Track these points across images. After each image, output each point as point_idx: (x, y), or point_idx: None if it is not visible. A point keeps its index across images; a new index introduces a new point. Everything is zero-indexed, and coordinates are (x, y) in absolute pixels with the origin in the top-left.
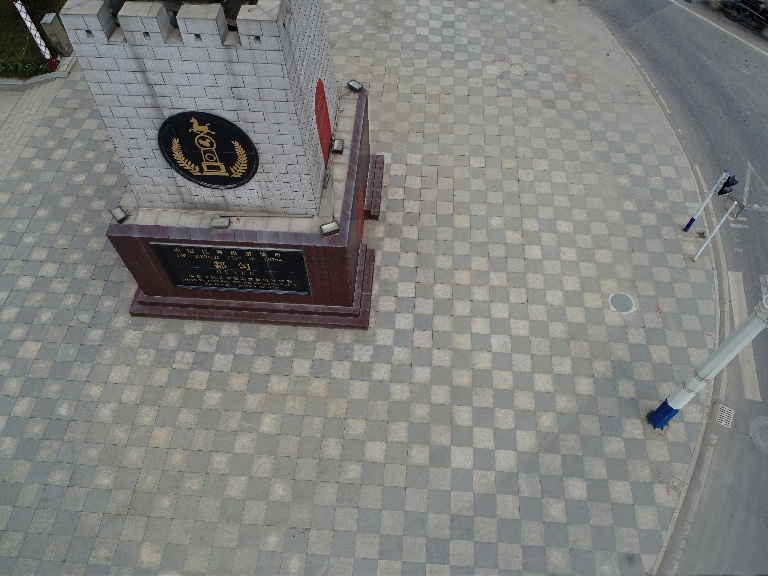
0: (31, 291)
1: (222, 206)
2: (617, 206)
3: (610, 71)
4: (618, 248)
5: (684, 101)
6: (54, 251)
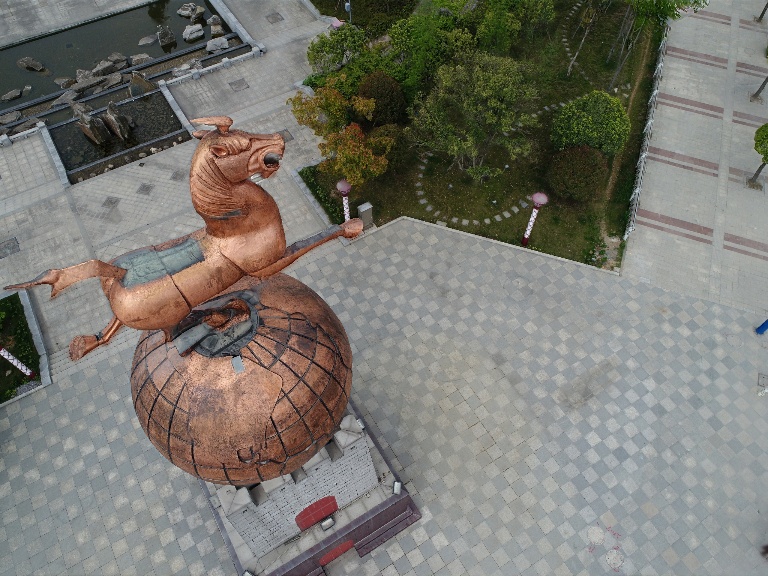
0: None
1: None
2: None
3: None
4: None
5: None
6: None
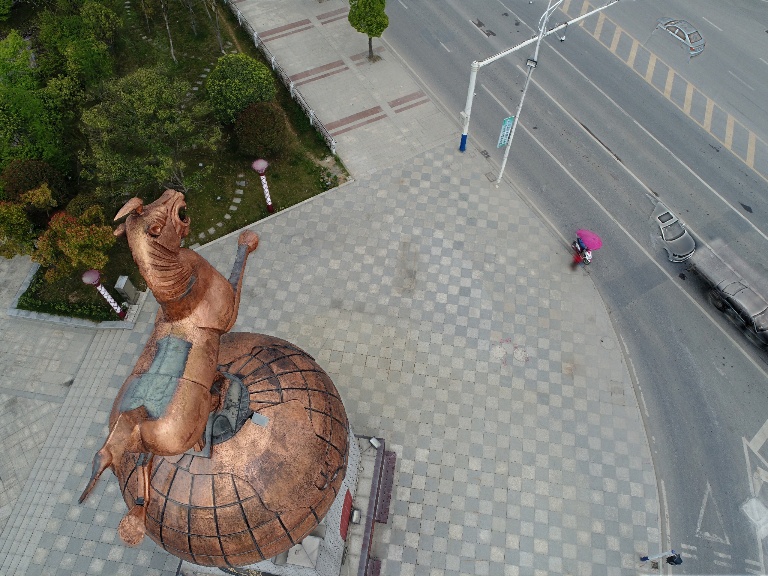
0: None
1: None
2: (588, 526)
3: (601, 362)
4: (583, 575)
5: (662, 403)
6: None
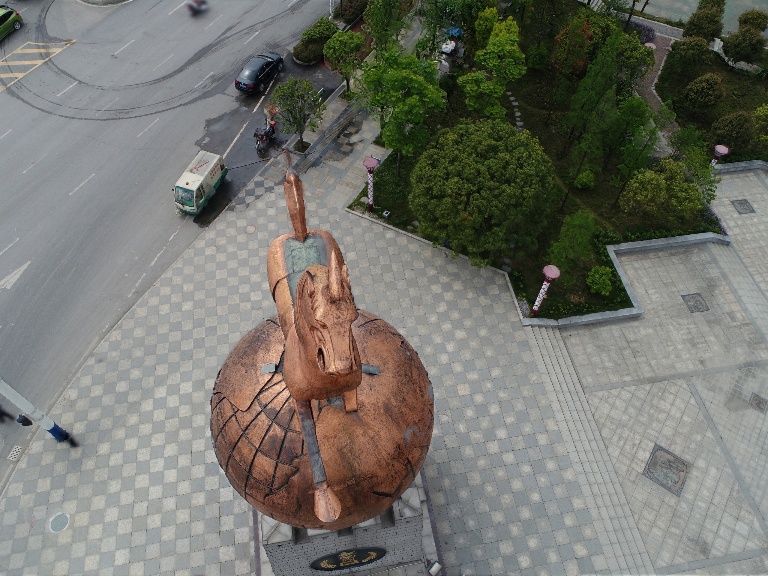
0: (492, 428)
1: None
2: None
3: None
4: None
5: None
6: (500, 463)
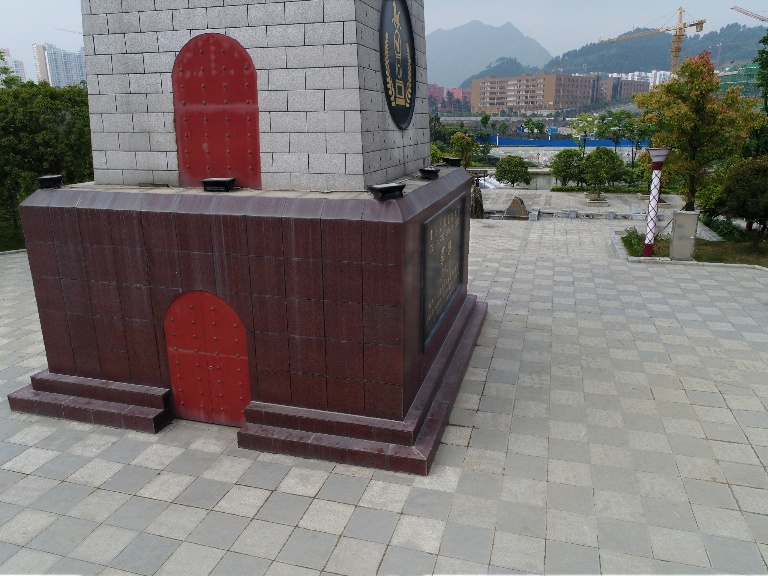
0: None
1: None
2: None
3: None
4: None
5: None
6: None
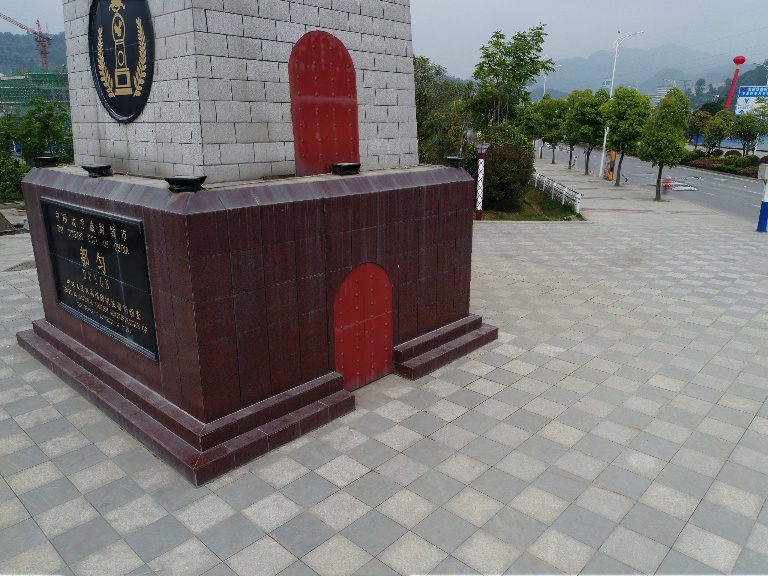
0: (6, 302)
1: (126, 162)
2: None
3: None
4: None
5: None
6: None
